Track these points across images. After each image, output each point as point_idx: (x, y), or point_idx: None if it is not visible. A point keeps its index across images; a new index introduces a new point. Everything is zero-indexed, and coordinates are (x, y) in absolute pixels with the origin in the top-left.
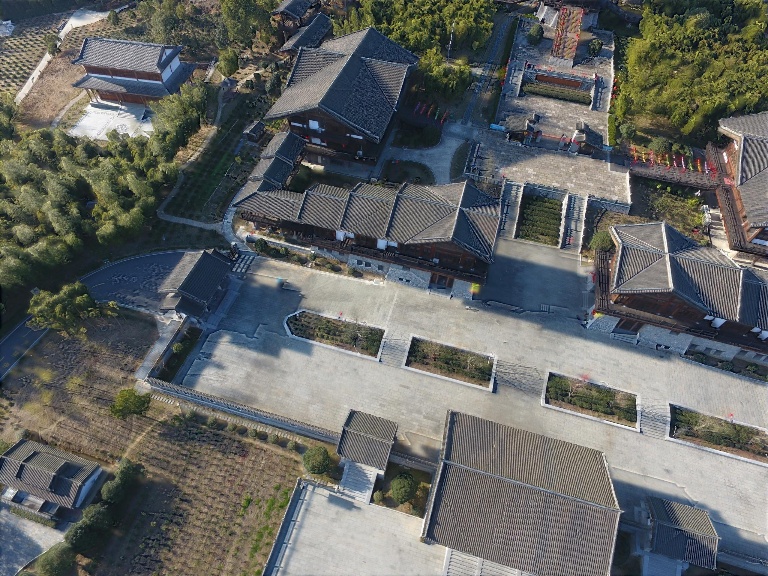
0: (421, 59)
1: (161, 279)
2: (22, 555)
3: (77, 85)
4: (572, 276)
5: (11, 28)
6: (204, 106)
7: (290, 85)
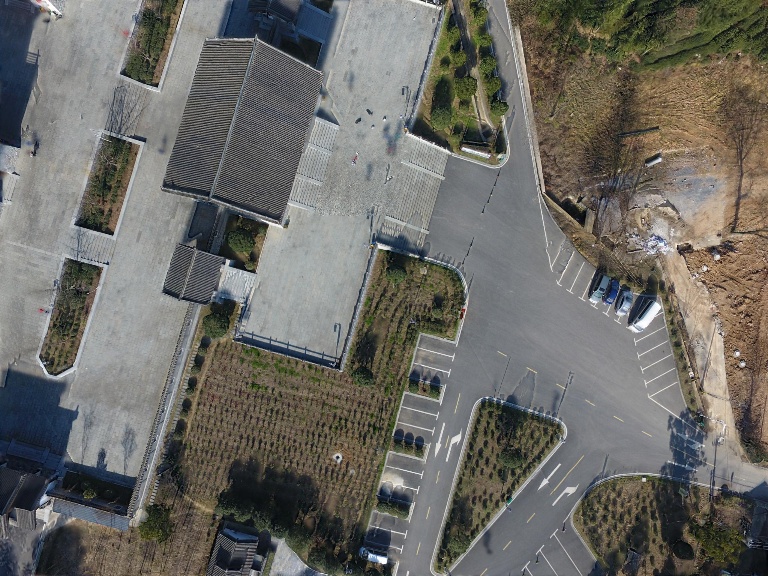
0: None
1: None
2: (296, 570)
3: None
4: None
5: None
6: None
7: None
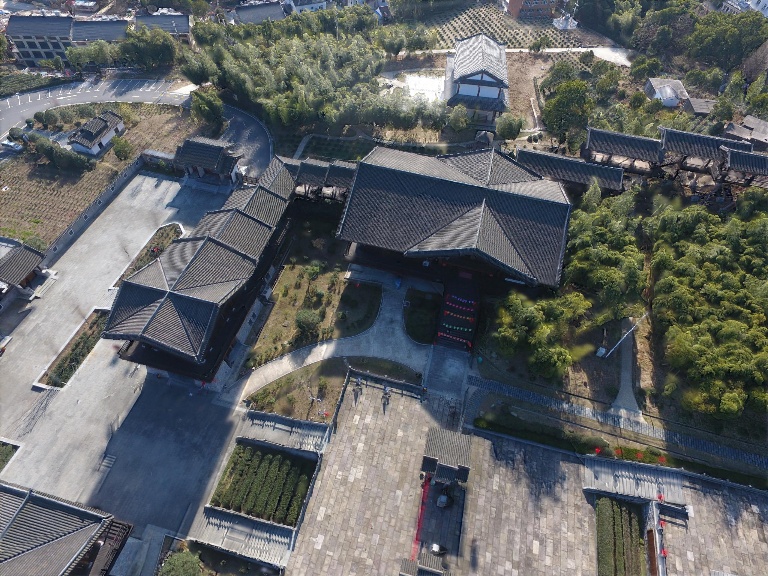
0: (570, 295)
1: (242, 151)
2: (65, 140)
3: (449, 56)
4: (149, 514)
5: (572, 27)
6: (438, 126)
7: (440, 158)
